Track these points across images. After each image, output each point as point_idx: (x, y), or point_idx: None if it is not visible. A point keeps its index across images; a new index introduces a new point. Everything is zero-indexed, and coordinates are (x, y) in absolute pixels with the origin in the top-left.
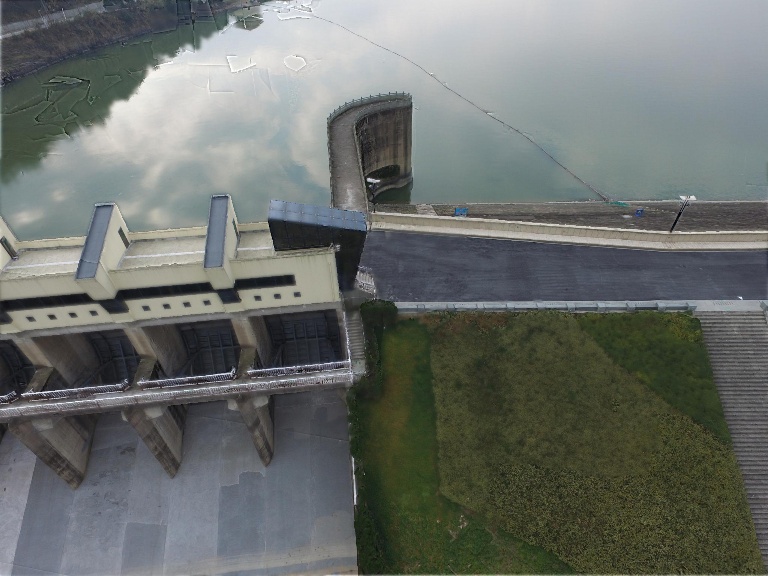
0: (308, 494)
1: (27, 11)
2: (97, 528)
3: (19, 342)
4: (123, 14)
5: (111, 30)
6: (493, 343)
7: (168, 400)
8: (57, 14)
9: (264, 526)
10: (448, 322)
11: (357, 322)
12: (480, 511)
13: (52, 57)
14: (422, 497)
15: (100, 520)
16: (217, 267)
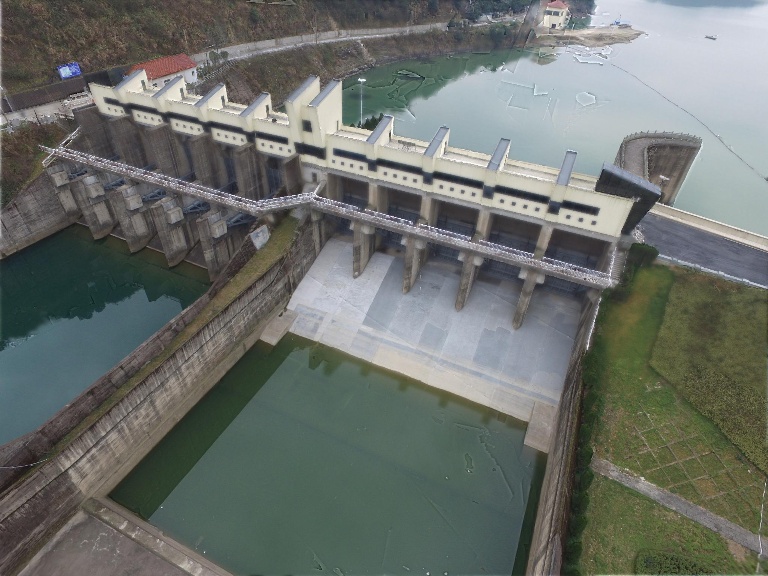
0: (537, 355)
1: (398, 21)
2: (411, 317)
3: (424, 199)
4: (459, 35)
5: (446, 45)
6: (722, 297)
7: (493, 255)
8: (415, 27)
9: (505, 359)
10: (692, 275)
11: (621, 257)
12: (674, 383)
13: (402, 56)
14: (634, 363)
15: (413, 314)
16: (564, 185)
